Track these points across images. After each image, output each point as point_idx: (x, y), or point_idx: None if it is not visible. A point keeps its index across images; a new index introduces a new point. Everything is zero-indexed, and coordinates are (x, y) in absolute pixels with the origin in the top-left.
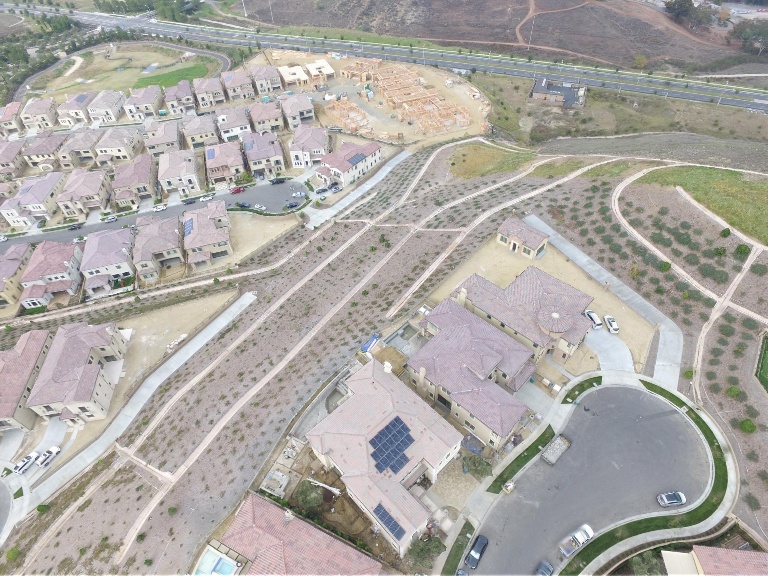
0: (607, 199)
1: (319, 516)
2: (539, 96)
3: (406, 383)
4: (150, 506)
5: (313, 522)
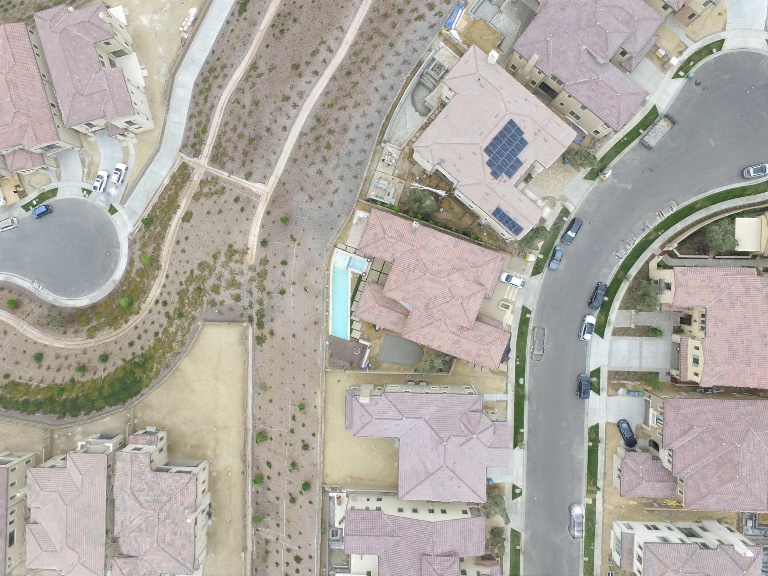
0: None
1: (431, 216)
2: None
3: None
4: (257, 216)
5: (428, 223)
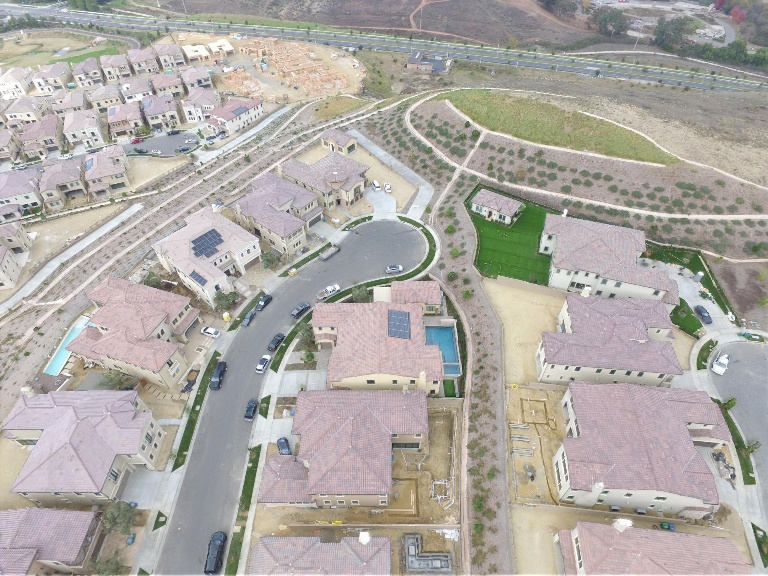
0: (403, 113)
1: None
2: (412, 66)
3: None
4: (45, 316)
5: None
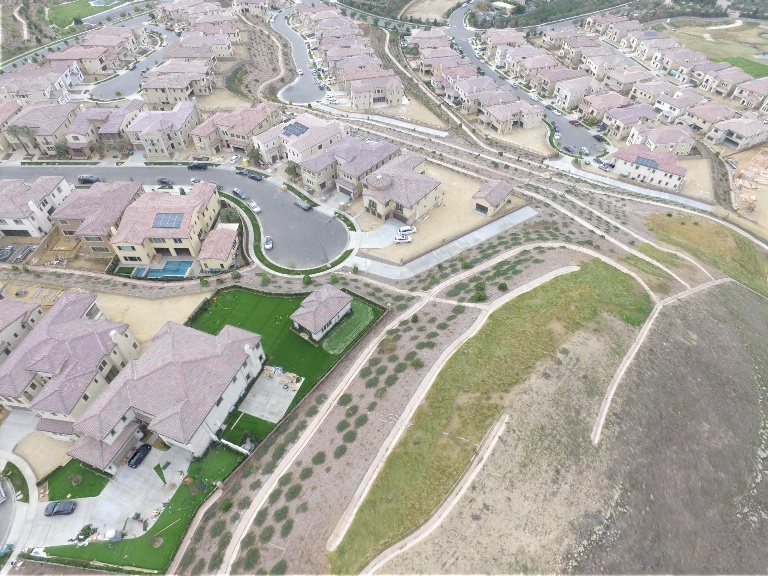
0: None
1: None
2: None
3: None
4: None
5: None
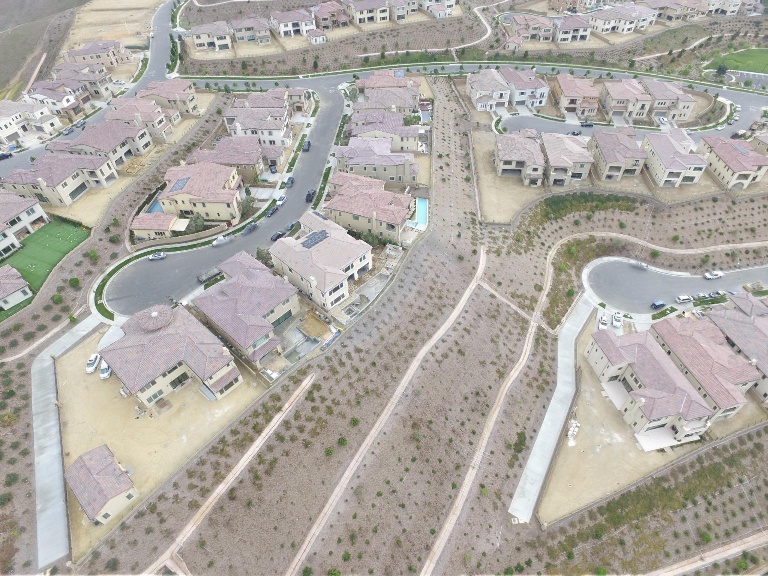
0: None
1: None
2: None
3: (303, 309)
4: (482, 270)
5: None
